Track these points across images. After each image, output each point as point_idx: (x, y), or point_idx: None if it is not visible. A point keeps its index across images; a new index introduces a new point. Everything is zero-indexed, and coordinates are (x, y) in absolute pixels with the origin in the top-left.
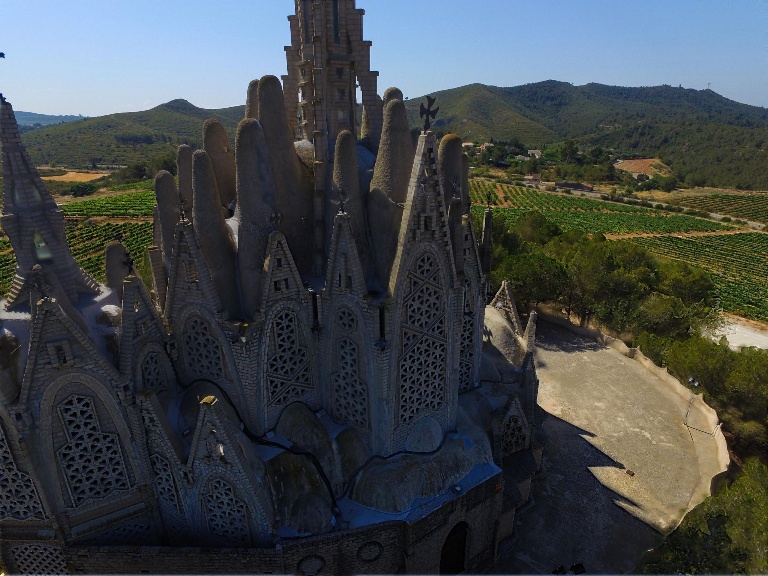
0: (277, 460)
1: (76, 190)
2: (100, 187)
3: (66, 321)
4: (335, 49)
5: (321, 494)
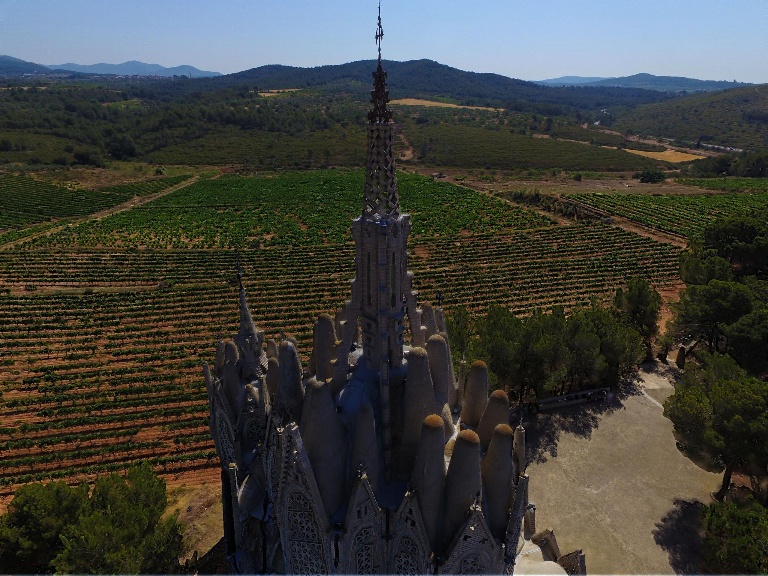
0: (254, 520)
1: (645, 176)
2: (669, 177)
3: (218, 392)
4: (368, 309)
5: (256, 559)
